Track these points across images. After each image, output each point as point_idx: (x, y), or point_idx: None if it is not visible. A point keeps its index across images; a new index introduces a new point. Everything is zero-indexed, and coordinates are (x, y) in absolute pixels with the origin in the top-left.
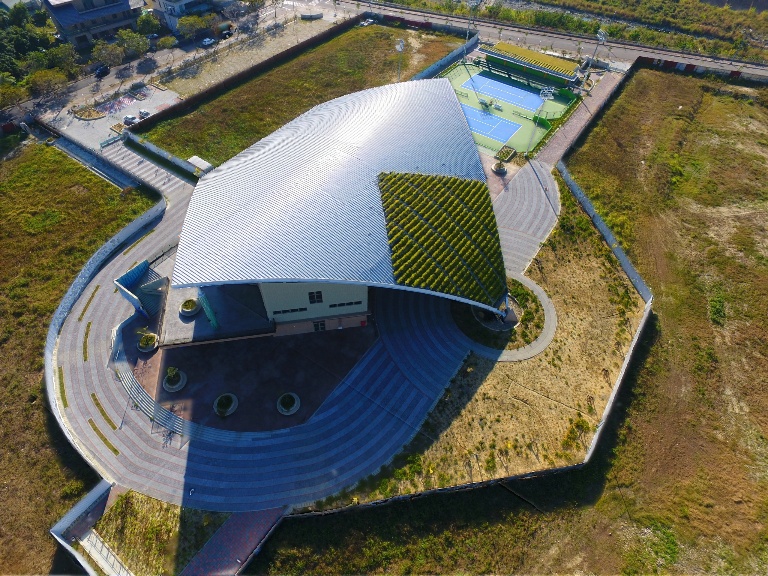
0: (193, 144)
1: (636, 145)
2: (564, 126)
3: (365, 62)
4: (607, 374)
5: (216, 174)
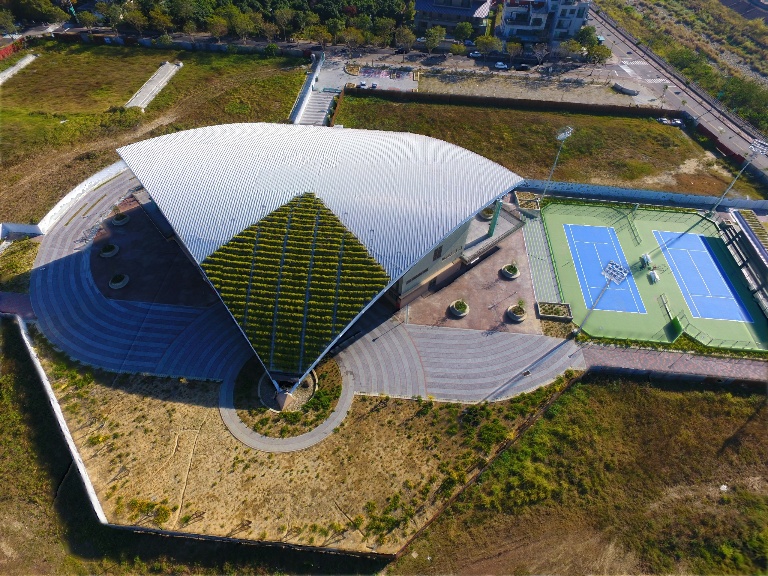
0: (364, 121)
1: (762, 467)
2: (695, 357)
3: (595, 149)
4: (244, 527)
5: (263, 124)
